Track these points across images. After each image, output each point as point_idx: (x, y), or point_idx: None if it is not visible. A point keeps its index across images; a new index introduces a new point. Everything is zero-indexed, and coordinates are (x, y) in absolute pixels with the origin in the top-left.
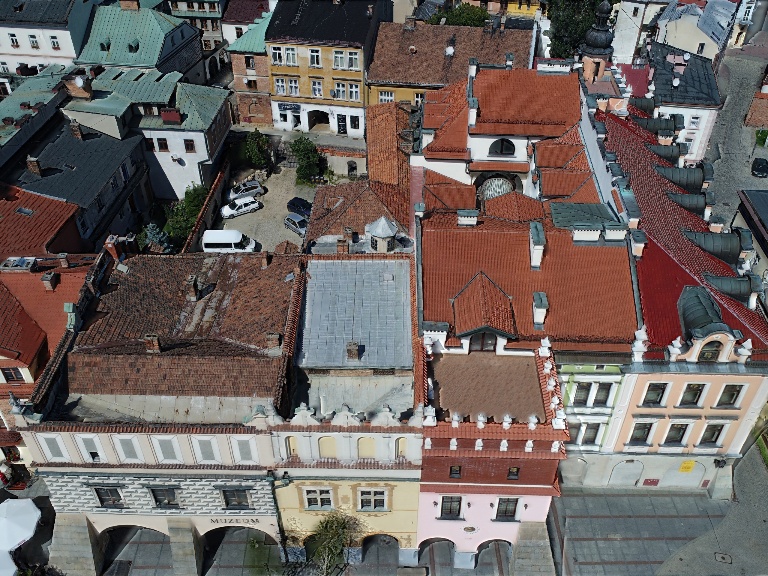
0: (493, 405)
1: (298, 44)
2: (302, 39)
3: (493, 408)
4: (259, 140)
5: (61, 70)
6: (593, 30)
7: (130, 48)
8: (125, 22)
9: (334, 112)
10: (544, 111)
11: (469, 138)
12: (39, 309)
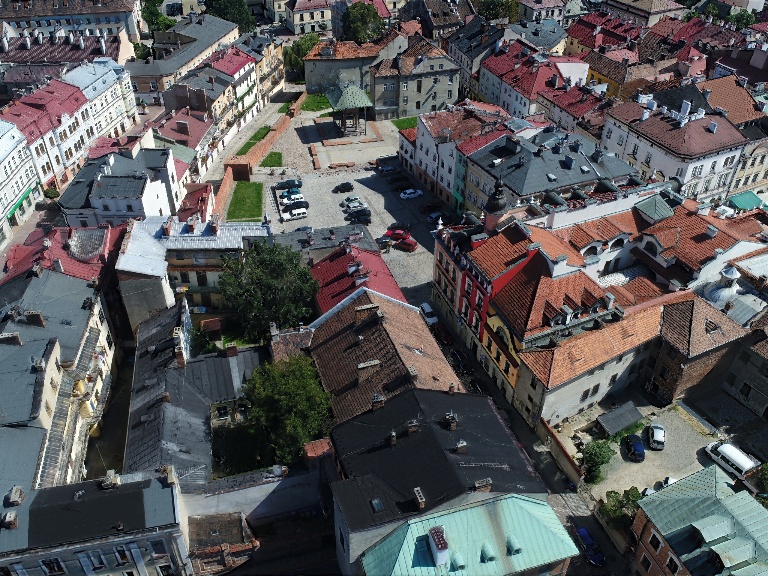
0: (764, 229)
1: None
2: (523, 454)
3: (765, 229)
4: (622, 497)
5: None
6: None
7: None
8: None
9: None
10: None
11: None
12: None
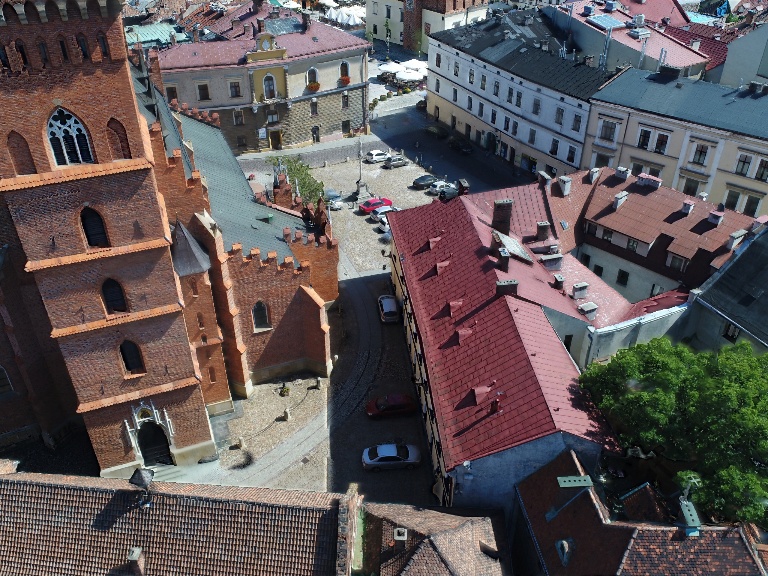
0: None
1: None
2: None
3: None
4: None
5: None
6: None
7: None
8: None
9: None
10: None
11: None
12: None
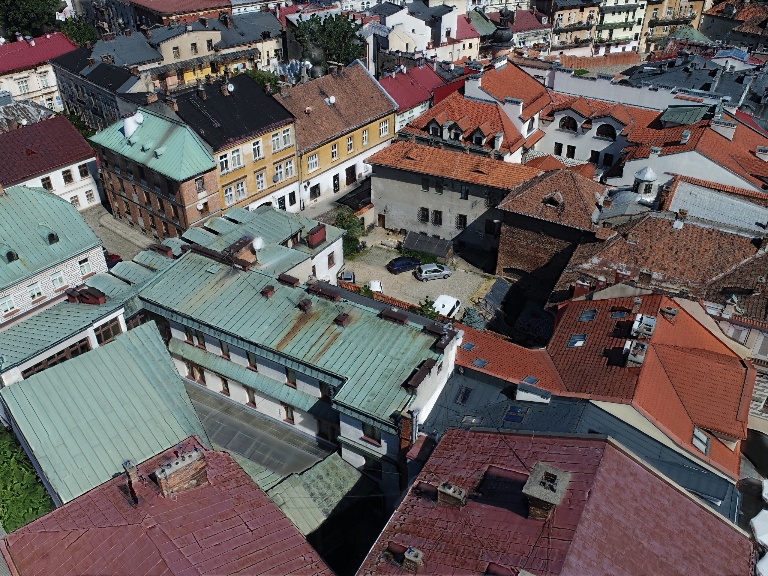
0: None
1: (243, 142)
2: (245, 136)
3: None
4: None
5: (115, 276)
6: (504, 30)
7: (49, 239)
8: (2, 216)
9: (276, 198)
10: (529, 91)
11: (522, 126)
12: (685, 340)
